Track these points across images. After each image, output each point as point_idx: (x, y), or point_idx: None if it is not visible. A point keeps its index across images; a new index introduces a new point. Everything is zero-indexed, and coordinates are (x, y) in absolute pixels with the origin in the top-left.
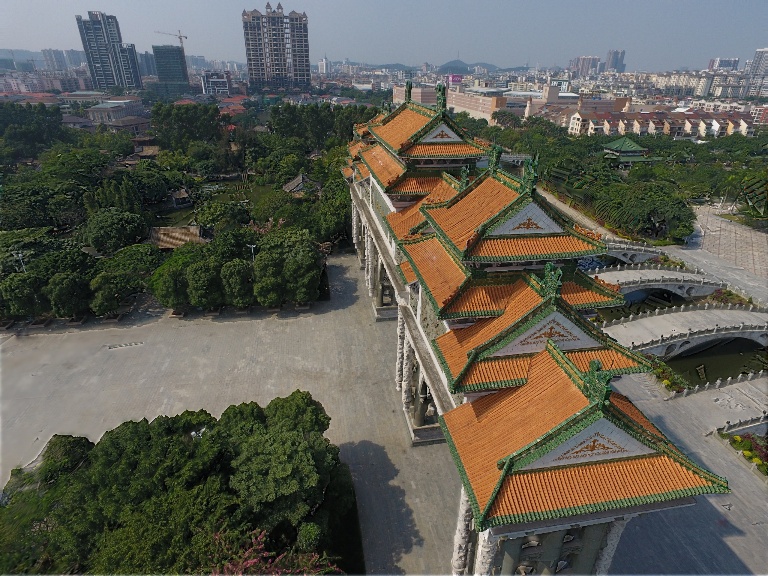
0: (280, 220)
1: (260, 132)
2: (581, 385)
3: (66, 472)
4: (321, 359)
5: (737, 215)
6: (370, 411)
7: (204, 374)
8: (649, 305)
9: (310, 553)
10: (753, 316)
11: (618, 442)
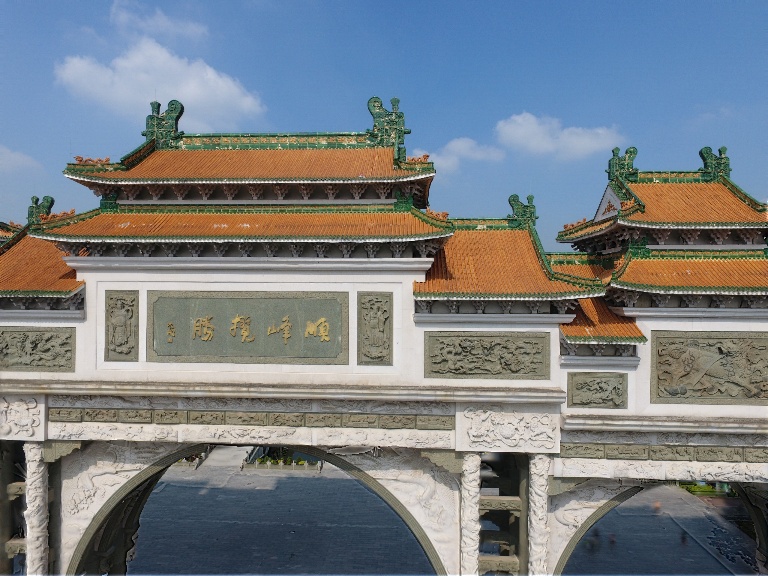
0: None
1: None
2: None
3: None
4: None
5: None
6: None
7: None
8: None
9: None
10: None
11: None
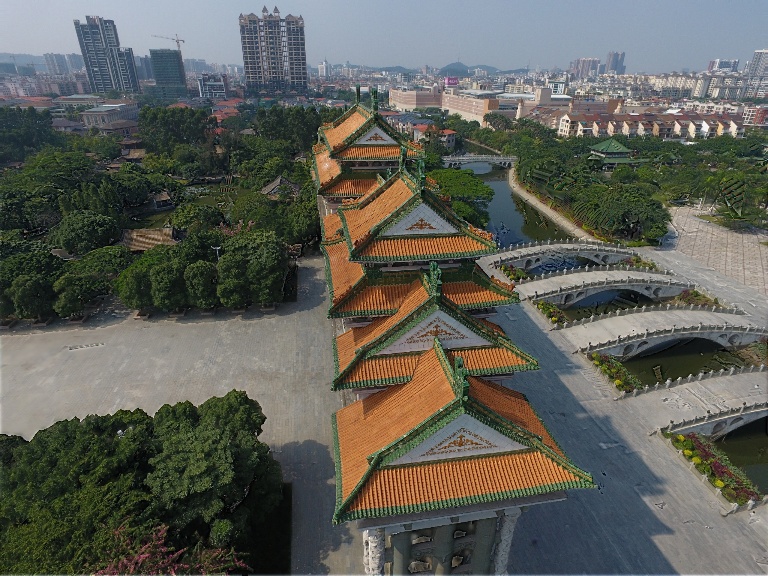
0: (249, 222)
1: (245, 135)
2: (452, 382)
3: None
4: (278, 360)
5: (716, 216)
6: (319, 411)
7: (160, 374)
8: (616, 306)
9: (217, 549)
10: (715, 316)
11: (486, 438)
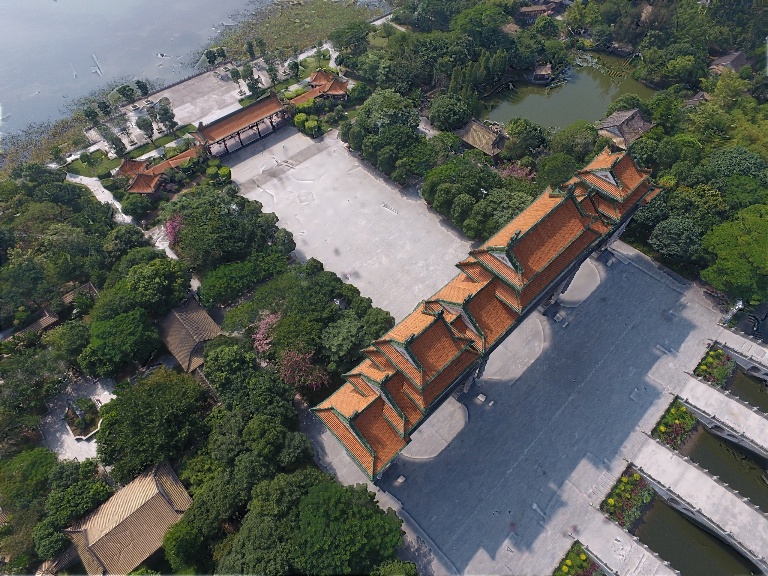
0: (533, 173)
1: None
2: None
3: (308, 274)
4: None
5: None
6: None
7: (401, 256)
8: None
9: None
10: None
11: None
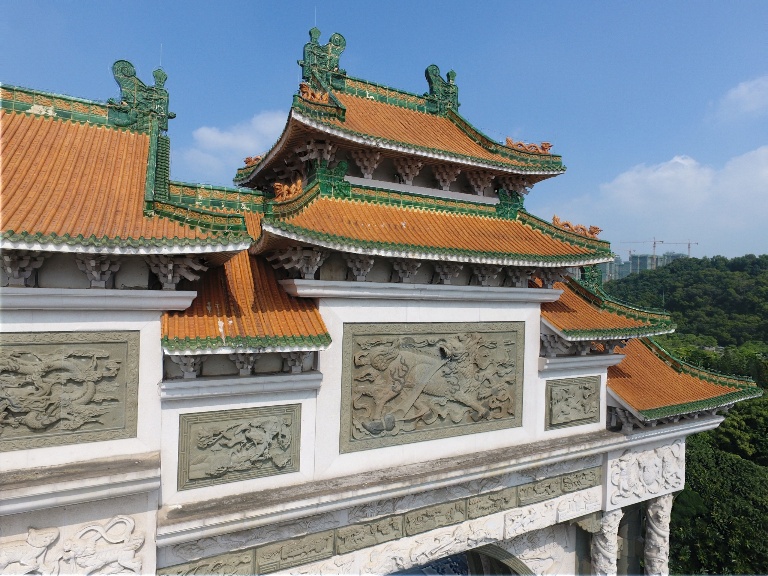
0: None
1: None
2: None
3: None
4: None
5: None
6: None
7: None
8: None
9: None
10: None
11: None
